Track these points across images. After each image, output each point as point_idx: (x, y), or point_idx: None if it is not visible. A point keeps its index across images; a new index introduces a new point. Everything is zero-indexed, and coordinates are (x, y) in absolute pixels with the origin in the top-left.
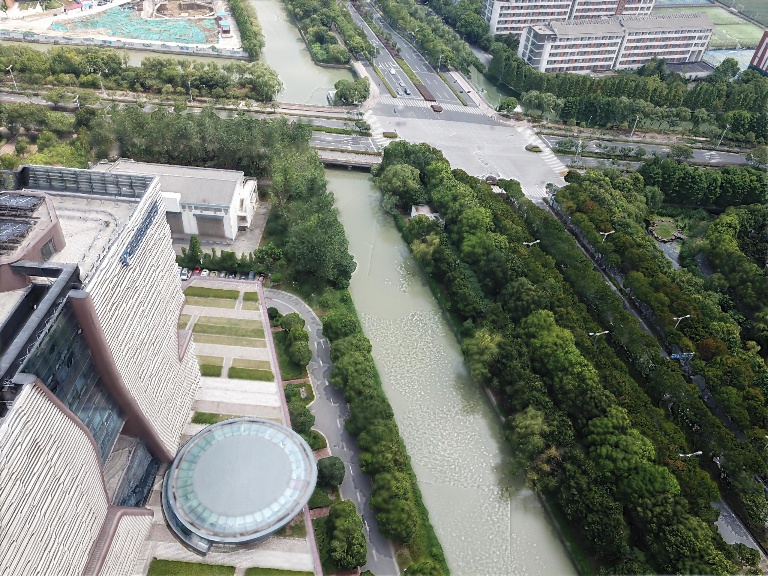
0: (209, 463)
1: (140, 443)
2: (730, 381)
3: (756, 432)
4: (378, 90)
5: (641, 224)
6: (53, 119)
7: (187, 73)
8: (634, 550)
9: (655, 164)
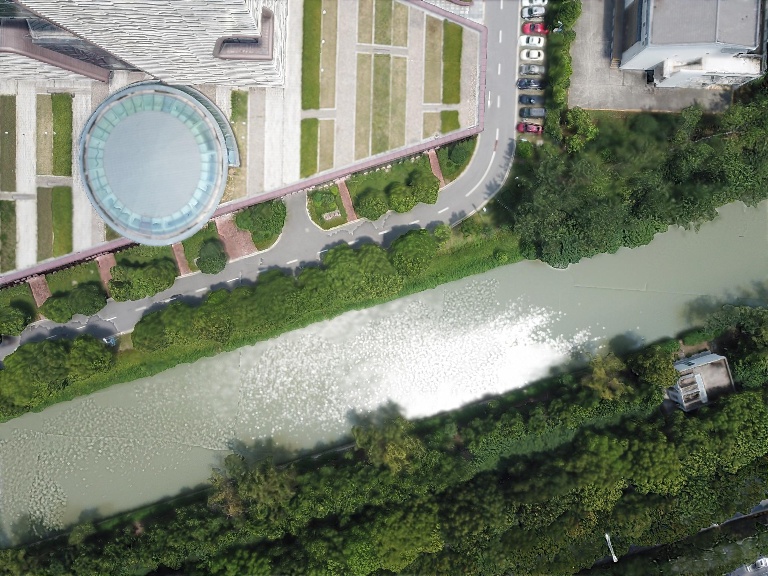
0: (160, 125)
1: None
2: None
3: None
4: None
5: None
6: None
7: None
8: (145, 568)
9: None
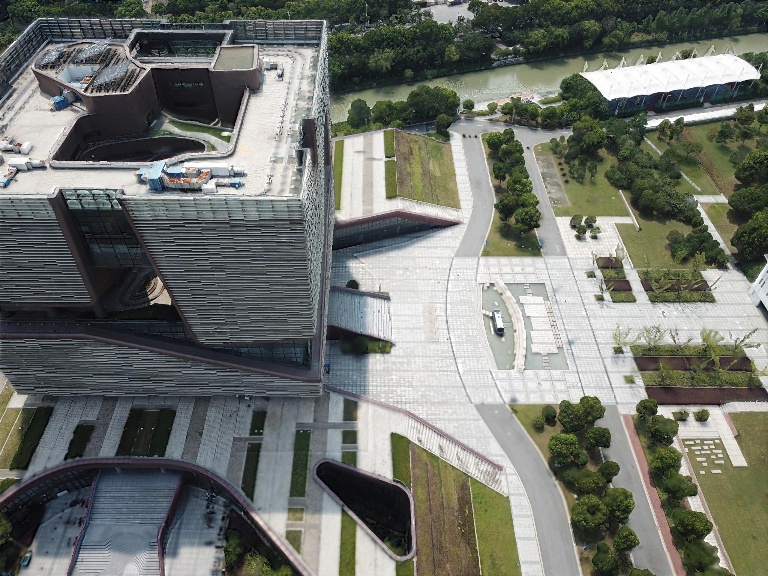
0: None
1: None
2: None
3: None
4: None
5: None
6: None
7: None
8: None
9: None
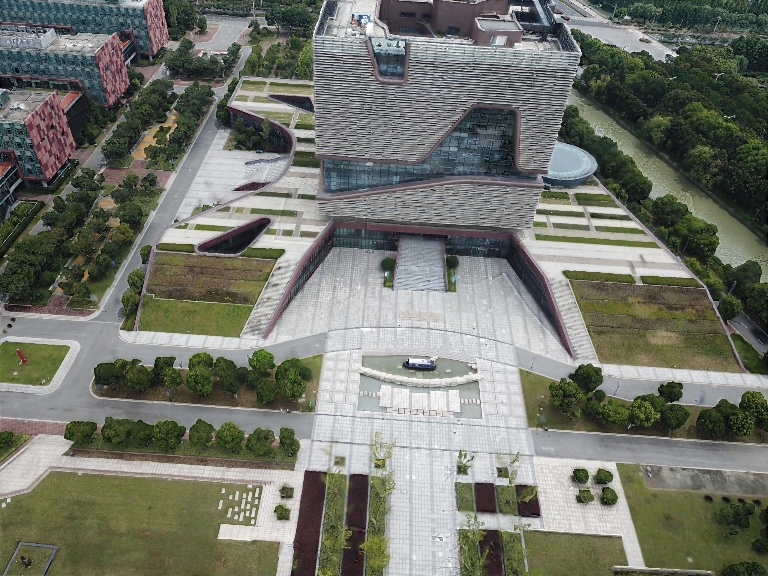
0: None
1: None
2: None
3: None
4: None
5: None
6: (314, 18)
7: None
8: None
9: (741, 41)
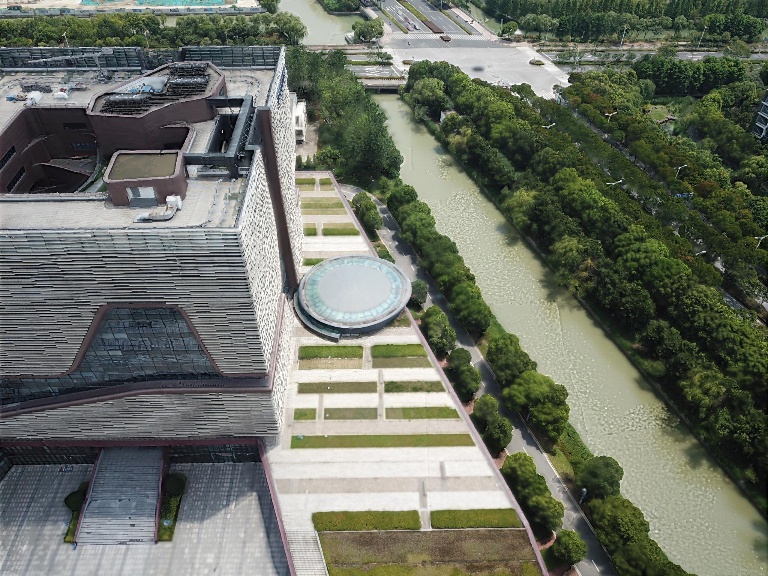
0: (327, 283)
1: (282, 259)
2: (724, 207)
3: (748, 239)
4: (390, 29)
5: (638, 108)
6: None
7: (221, 26)
8: (660, 321)
9: (645, 60)
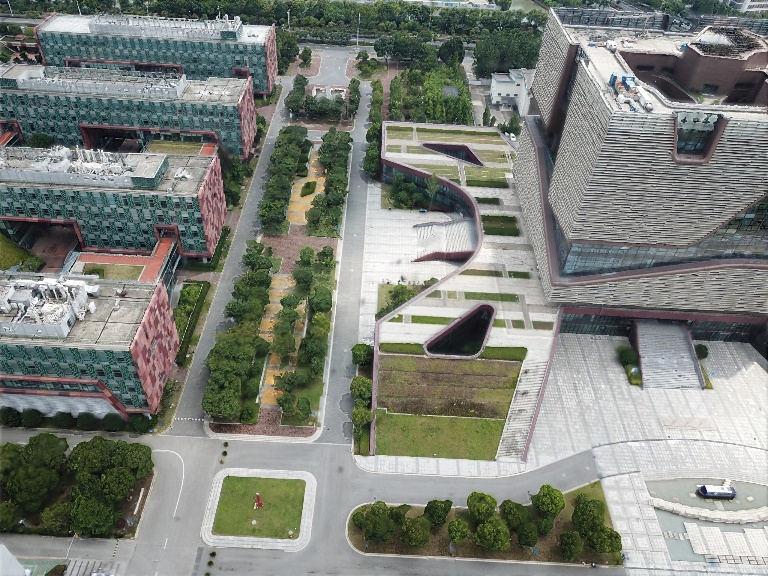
0: None
1: None
2: None
3: None
4: None
5: None
6: (428, 48)
7: (489, 18)
8: None
9: None
